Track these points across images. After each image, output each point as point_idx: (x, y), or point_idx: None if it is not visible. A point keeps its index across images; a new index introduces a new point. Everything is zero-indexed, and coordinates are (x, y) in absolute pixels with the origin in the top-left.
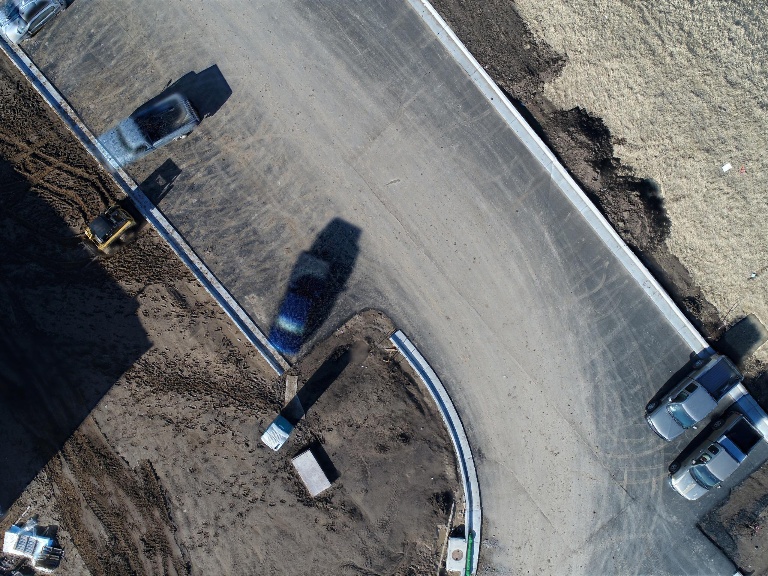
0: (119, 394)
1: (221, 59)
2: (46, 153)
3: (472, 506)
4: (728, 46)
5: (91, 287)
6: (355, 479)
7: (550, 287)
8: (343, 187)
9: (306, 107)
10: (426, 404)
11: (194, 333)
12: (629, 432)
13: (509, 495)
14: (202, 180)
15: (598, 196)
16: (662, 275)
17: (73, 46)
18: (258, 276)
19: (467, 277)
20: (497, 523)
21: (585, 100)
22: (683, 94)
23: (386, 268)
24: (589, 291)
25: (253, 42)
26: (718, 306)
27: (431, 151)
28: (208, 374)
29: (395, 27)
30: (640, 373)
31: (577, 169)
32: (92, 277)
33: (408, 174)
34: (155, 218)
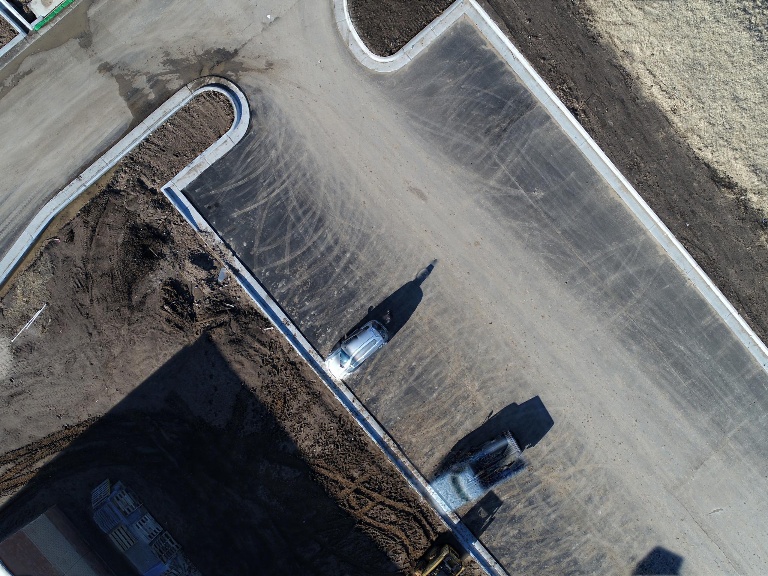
0: None
1: (543, 390)
2: (370, 488)
3: None
4: None
5: None
6: None
7: None
8: (665, 516)
9: (628, 437)
10: None
11: None
12: None
13: None
14: (523, 511)
15: None
16: None
17: (395, 379)
18: None
19: None
20: None
21: None
22: None
23: None
24: None
25: (576, 373)
26: None
27: (755, 480)
28: None
29: (720, 358)
30: None
31: None
32: None
33: (731, 503)
34: (477, 551)
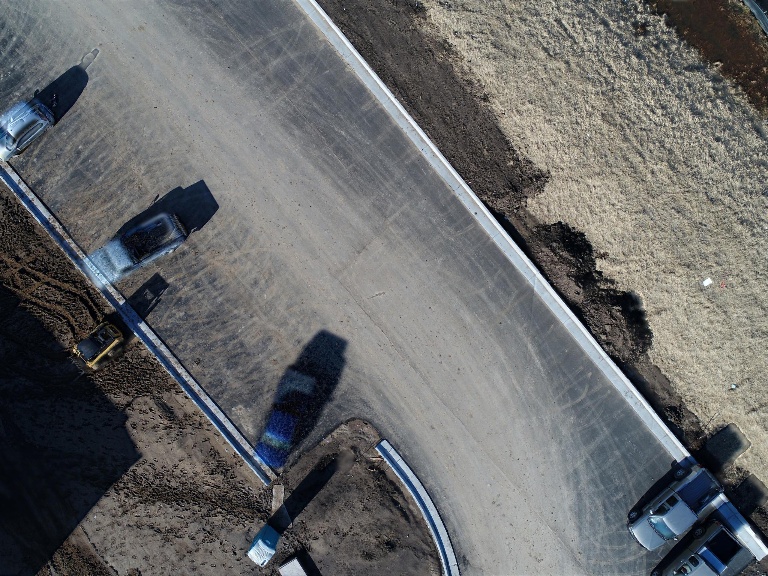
0: (108, 505)
1: (208, 174)
2: (35, 269)
3: None
4: (709, 162)
5: (80, 400)
6: None
7: (533, 397)
8: (329, 300)
9: (292, 221)
10: (411, 512)
11: (182, 444)
12: (612, 539)
13: None
14: (189, 294)
15: (581, 308)
16: (644, 385)
17: (61, 162)
18: (245, 388)
19: (451, 388)
20: None
21: (568, 215)
22: (664, 210)
23: (371, 379)
24: (572, 401)
25: (239, 158)
26: (699, 415)
27: (416, 264)
28: (196, 484)
29: (380, 143)
30: (622, 481)
31: (560, 283)
32: (81, 391)
33: (393, 287)
34: (143, 332)
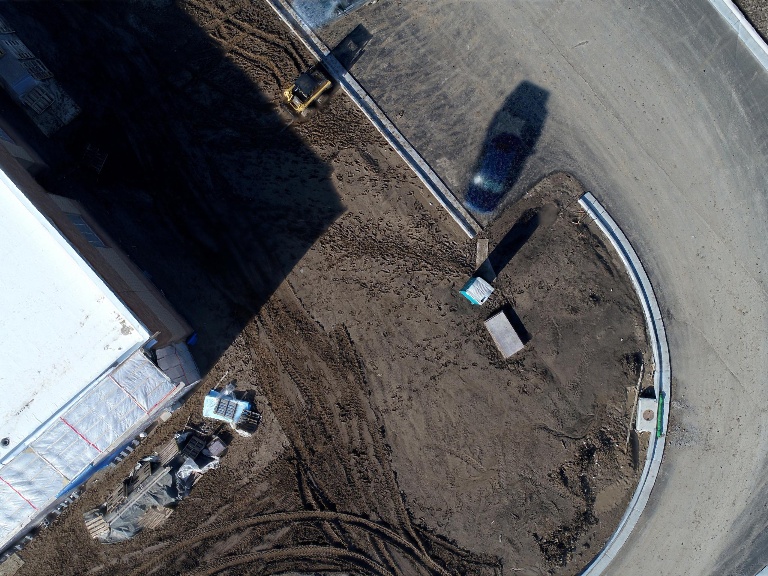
0: (314, 259)
1: None
2: (240, 19)
3: (662, 366)
4: None
5: (286, 152)
6: (546, 341)
7: (737, 146)
8: (532, 50)
9: None
10: (615, 266)
11: (387, 197)
12: None
13: (698, 355)
14: (393, 45)
15: None
16: None
17: None
18: (449, 140)
19: (655, 138)
20: (686, 383)
21: None
22: None
23: (575, 130)
24: None
25: None
26: None
27: (619, 12)
28: (401, 238)
29: None
30: None
31: (765, 26)
32: (287, 142)
33: (596, 36)
34: (348, 83)
